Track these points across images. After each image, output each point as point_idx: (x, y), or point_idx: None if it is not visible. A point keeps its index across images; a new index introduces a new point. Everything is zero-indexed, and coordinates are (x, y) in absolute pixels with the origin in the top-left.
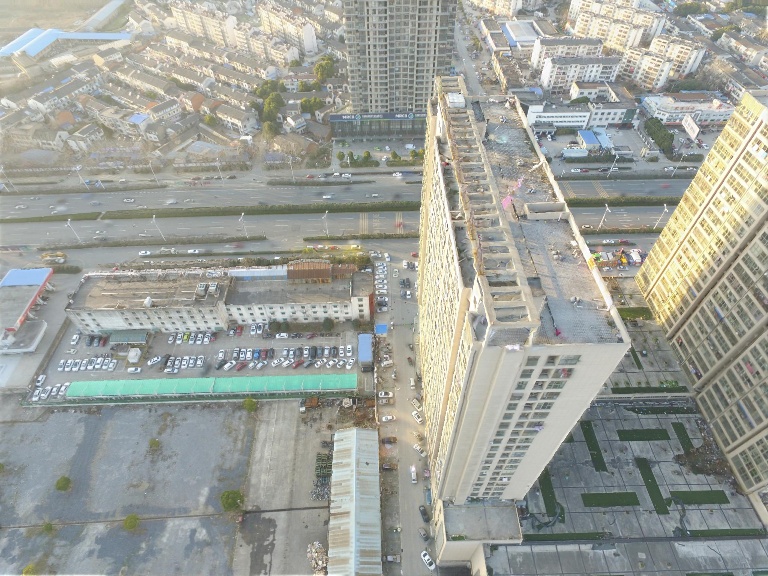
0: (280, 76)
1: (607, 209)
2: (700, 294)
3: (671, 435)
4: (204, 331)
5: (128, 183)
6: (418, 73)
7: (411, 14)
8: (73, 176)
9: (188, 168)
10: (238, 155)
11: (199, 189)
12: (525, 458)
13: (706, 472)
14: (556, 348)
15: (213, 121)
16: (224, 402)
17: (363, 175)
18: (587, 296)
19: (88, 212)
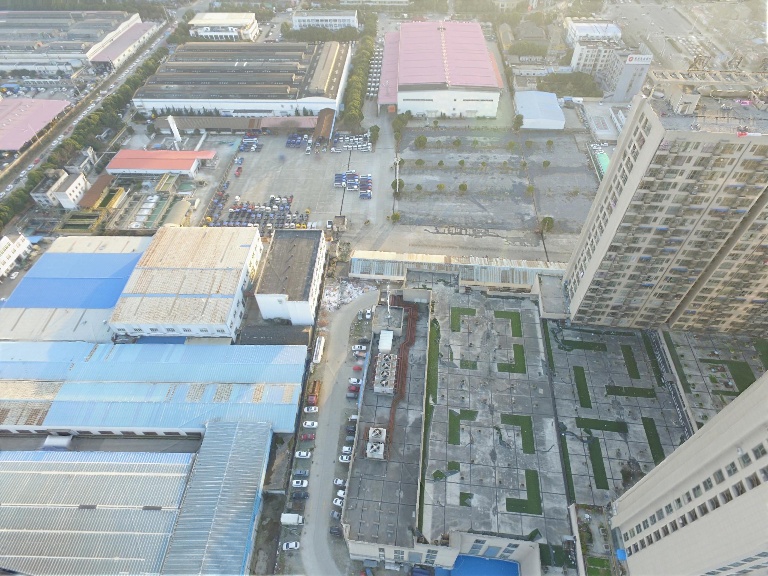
0: None
1: None
2: None
3: None
4: None
5: None
6: None
7: None
8: None
9: None
10: None
11: None
12: (596, 249)
13: (626, 483)
14: None
15: None
16: None
17: None
18: None
19: None
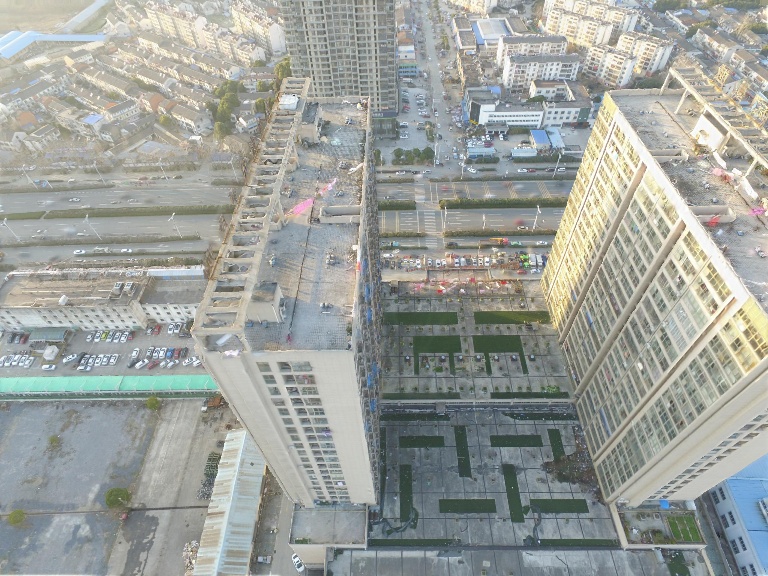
0: (243, 76)
1: (538, 210)
2: (578, 298)
3: (544, 442)
4: (123, 330)
5: (77, 183)
6: (361, 73)
7: (348, 14)
8: (26, 176)
9: (137, 168)
10: (187, 155)
11: (144, 189)
12: (342, 463)
13: (572, 480)
14: (278, 354)
15: (168, 121)
16: (130, 400)
17: None
18: (340, 302)
19: (33, 211)
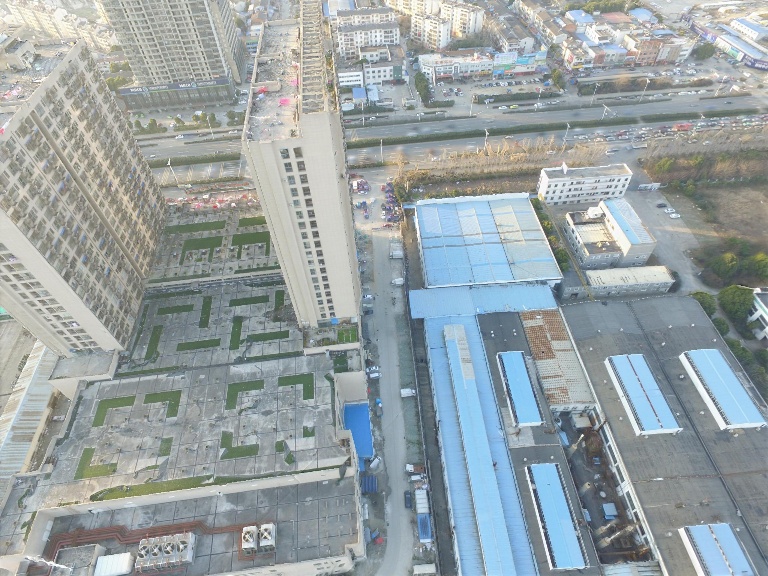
0: None
1: None
2: None
3: (271, 299)
4: None
5: None
6: (185, 45)
7: None
8: None
9: None
10: None
11: None
12: (56, 297)
13: (283, 320)
14: None
15: None
16: None
17: (149, 140)
18: None
19: None
